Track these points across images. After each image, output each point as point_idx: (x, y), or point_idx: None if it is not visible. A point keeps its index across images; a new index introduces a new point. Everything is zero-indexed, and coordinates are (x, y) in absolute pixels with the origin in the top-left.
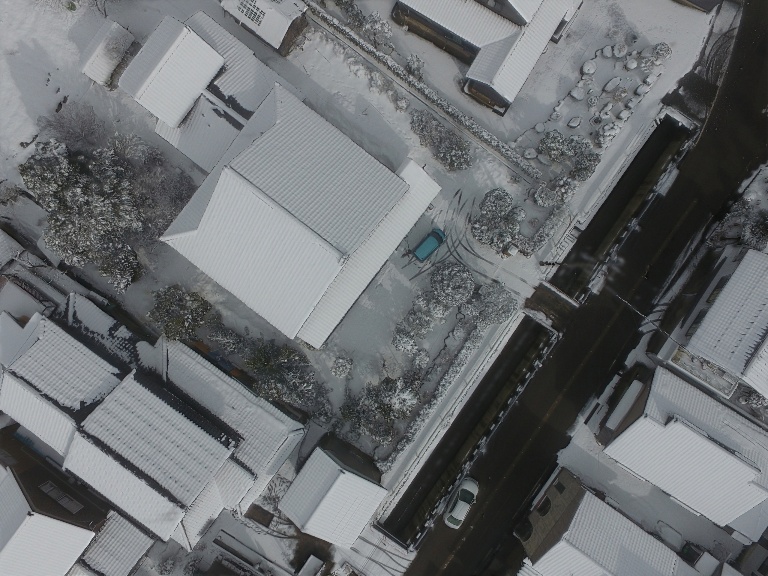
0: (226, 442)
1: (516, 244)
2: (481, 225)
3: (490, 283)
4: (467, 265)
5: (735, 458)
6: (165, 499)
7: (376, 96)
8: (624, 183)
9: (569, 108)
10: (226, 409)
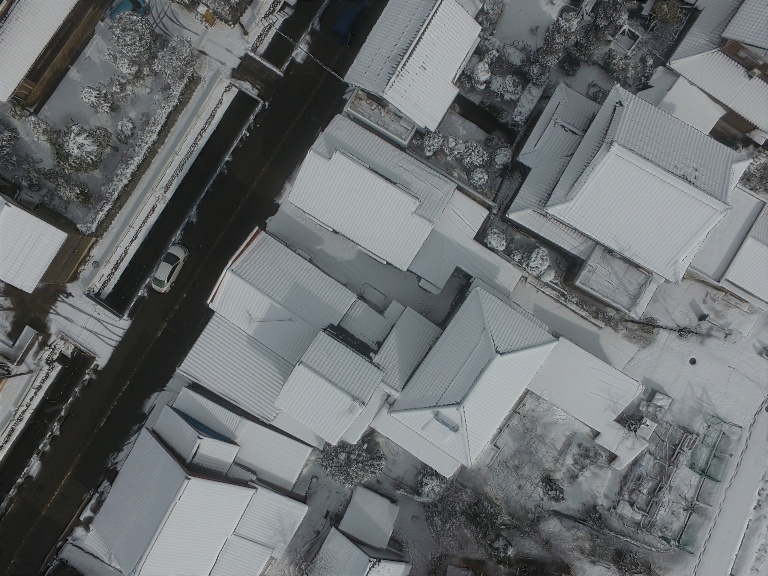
0: None
1: (206, 4)
2: None
3: (196, 54)
4: (173, 36)
5: (393, 186)
6: None
7: None
8: None
9: None
10: None
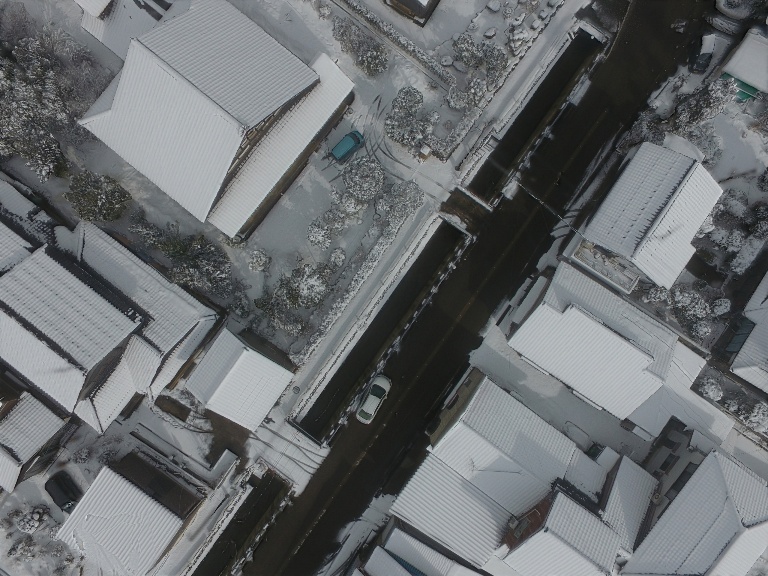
0: (133, 316)
1: (429, 144)
2: (392, 121)
3: None
4: (385, 169)
5: (628, 344)
6: (66, 362)
7: (300, 4)
8: (540, 96)
9: (486, 19)
10: (138, 291)
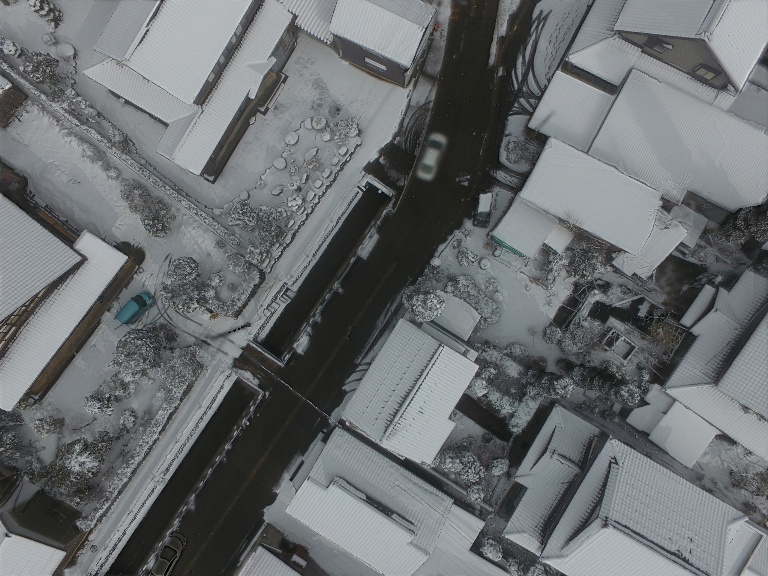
0: None
1: (210, 308)
2: (166, 292)
3: (199, 344)
4: (177, 326)
5: (389, 520)
6: None
7: (89, 165)
8: (336, 246)
9: (273, 177)
10: None
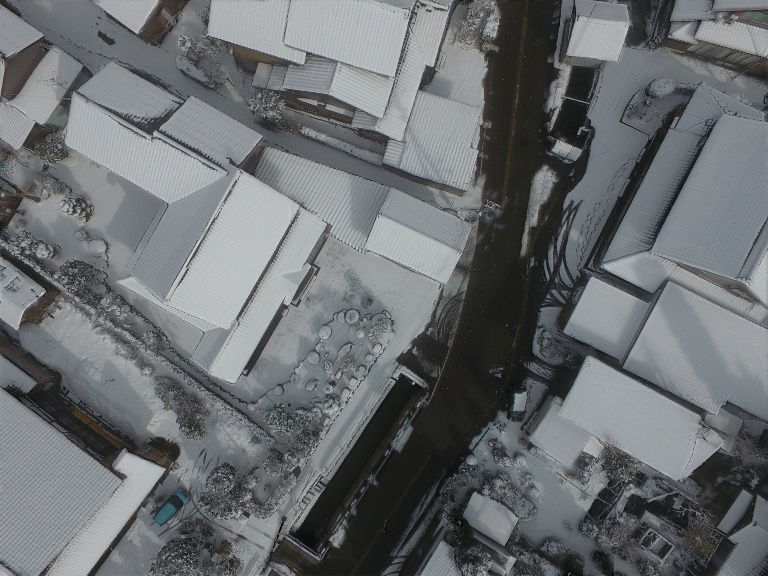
0: None
1: (248, 512)
2: (205, 503)
3: (236, 538)
4: (213, 521)
5: None
6: None
7: (123, 362)
8: (369, 433)
9: (307, 370)
10: None
